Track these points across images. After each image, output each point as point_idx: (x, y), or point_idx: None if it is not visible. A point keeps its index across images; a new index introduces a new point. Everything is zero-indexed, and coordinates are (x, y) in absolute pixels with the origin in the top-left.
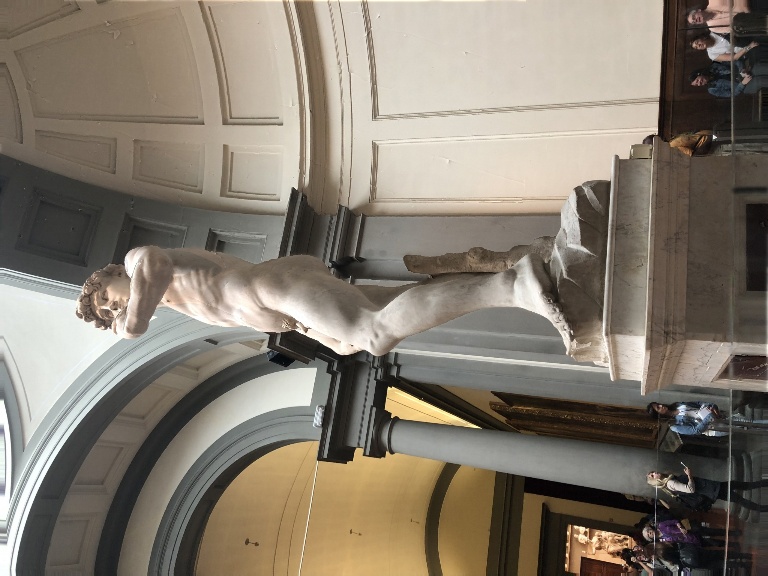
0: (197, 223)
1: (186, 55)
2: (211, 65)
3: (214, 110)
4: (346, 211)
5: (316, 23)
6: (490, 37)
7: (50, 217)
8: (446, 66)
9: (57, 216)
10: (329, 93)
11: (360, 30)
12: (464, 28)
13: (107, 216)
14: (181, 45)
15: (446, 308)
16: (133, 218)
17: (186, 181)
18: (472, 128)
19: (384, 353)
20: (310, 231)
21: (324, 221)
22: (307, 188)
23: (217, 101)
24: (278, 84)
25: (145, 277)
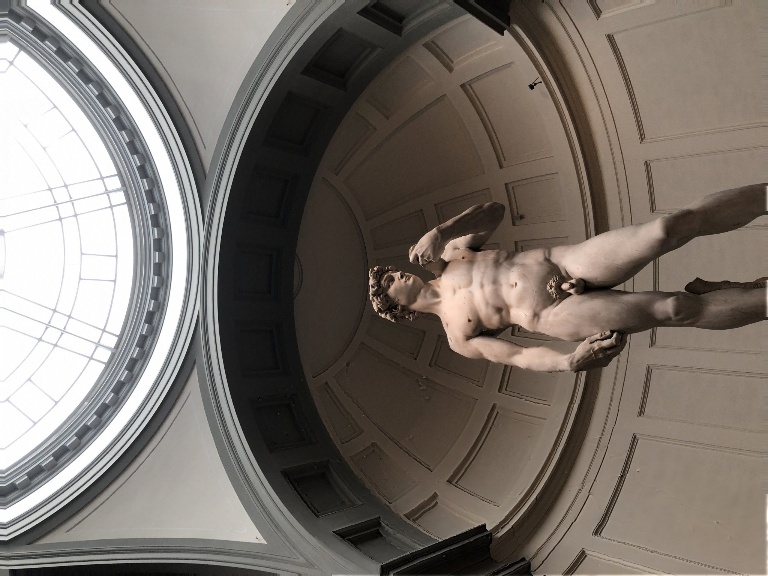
0: (373, 506)
1: (456, 430)
2: (470, 442)
3: (447, 469)
4: (528, 564)
5: (579, 453)
6: (748, 520)
7: (282, 416)
8: (691, 526)
9: (286, 420)
10: (559, 502)
11: (616, 470)
12: (722, 502)
13: (315, 449)
14: (459, 420)
15: (753, 186)
16: (329, 467)
17: (384, 492)
18: (705, 574)
19: (671, 224)
20: (478, 561)
21: (497, 563)
22: (496, 539)
23: (454, 467)
24: (516, 479)
25: (484, 206)
